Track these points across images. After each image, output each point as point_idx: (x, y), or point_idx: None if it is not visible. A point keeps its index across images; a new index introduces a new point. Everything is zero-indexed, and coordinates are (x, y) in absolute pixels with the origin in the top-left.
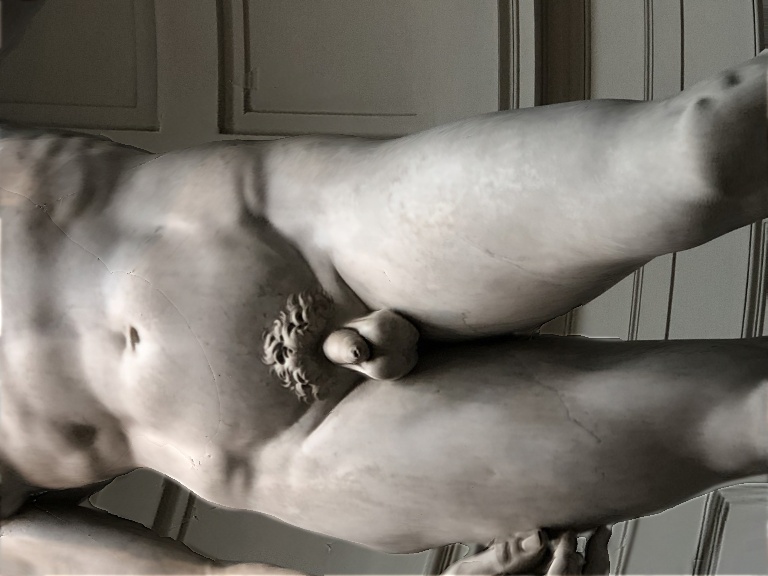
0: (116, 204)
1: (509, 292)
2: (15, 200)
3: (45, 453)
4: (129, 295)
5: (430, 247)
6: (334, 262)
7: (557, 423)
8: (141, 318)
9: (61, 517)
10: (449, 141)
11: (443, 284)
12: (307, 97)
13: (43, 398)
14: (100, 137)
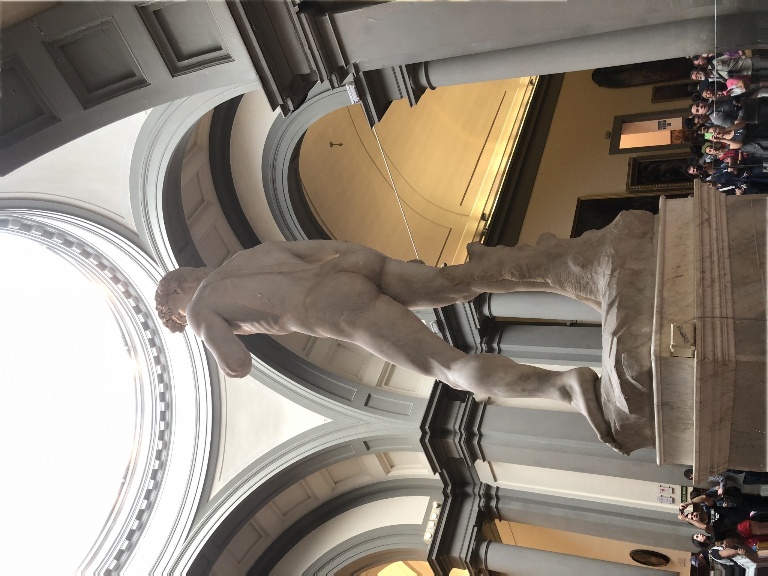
0: None
1: None
2: None
3: None
4: None
5: None
6: None
7: None
8: None
9: None
10: None
11: None
12: None
13: None
14: (263, 318)
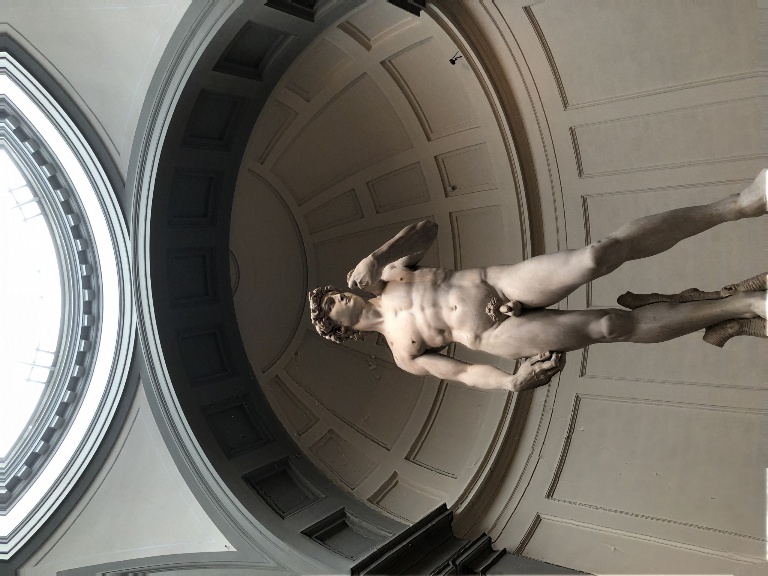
0: (452, 280)
1: (544, 294)
2: (429, 279)
3: (433, 336)
4: (455, 298)
5: (526, 284)
6: (502, 290)
7: (554, 325)
8: (458, 303)
9: (434, 354)
10: (531, 261)
11: (529, 293)
12: None
13: (434, 322)
14: None
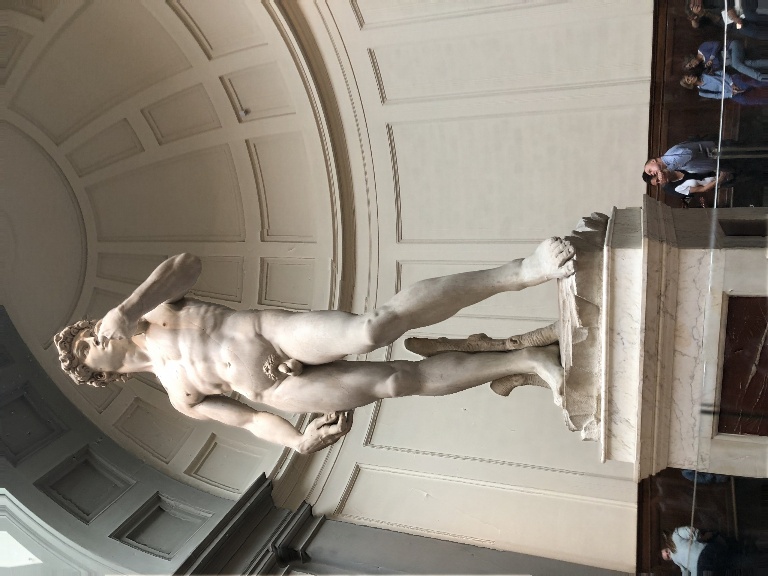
0: (223, 328)
1: (324, 358)
2: (196, 327)
3: (209, 390)
4: (227, 354)
5: (303, 348)
6: (280, 346)
7: (338, 388)
8: (231, 361)
9: (215, 400)
10: (307, 321)
11: (307, 356)
12: (283, 232)
13: (207, 378)
14: (219, 305)
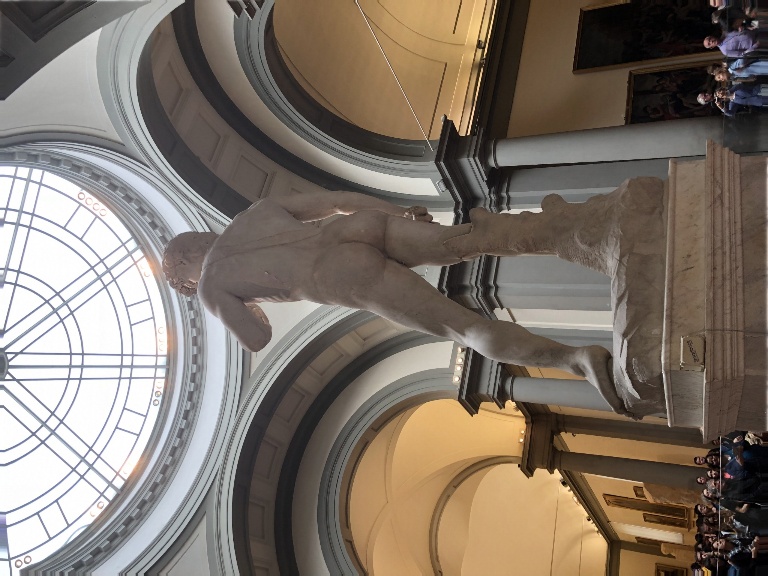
0: None
1: None
2: None
3: None
4: None
5: None
6: None
7: None
8: None
9: None
10: None
11: None
12: None
13: None
14: (275, 294)
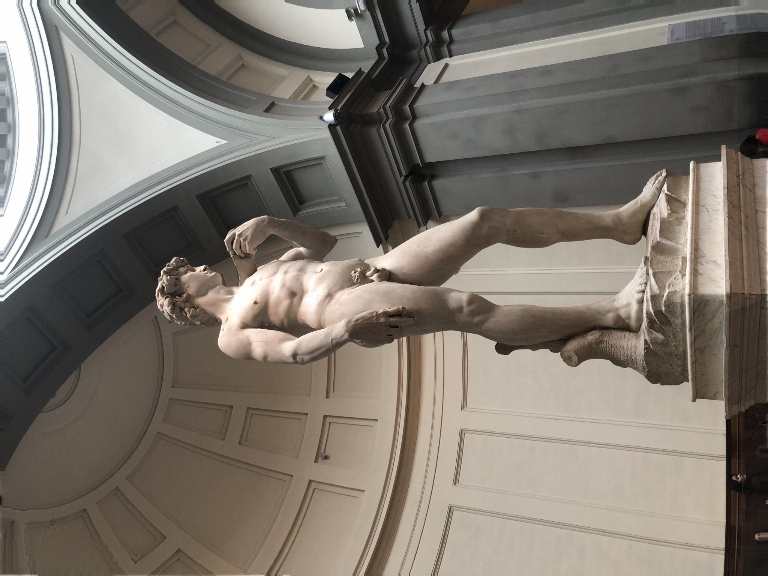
0: None
1: (418, 259)
2: None
3: (280, 299)
4: None
5: None
6: None
7: None
8: None
9: None
10: None
11: None
12: None
13: (290, 282)
14: None
